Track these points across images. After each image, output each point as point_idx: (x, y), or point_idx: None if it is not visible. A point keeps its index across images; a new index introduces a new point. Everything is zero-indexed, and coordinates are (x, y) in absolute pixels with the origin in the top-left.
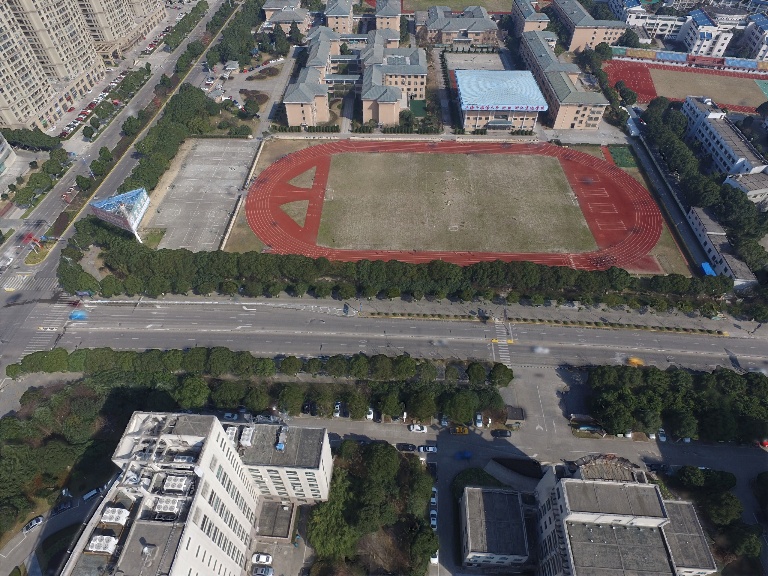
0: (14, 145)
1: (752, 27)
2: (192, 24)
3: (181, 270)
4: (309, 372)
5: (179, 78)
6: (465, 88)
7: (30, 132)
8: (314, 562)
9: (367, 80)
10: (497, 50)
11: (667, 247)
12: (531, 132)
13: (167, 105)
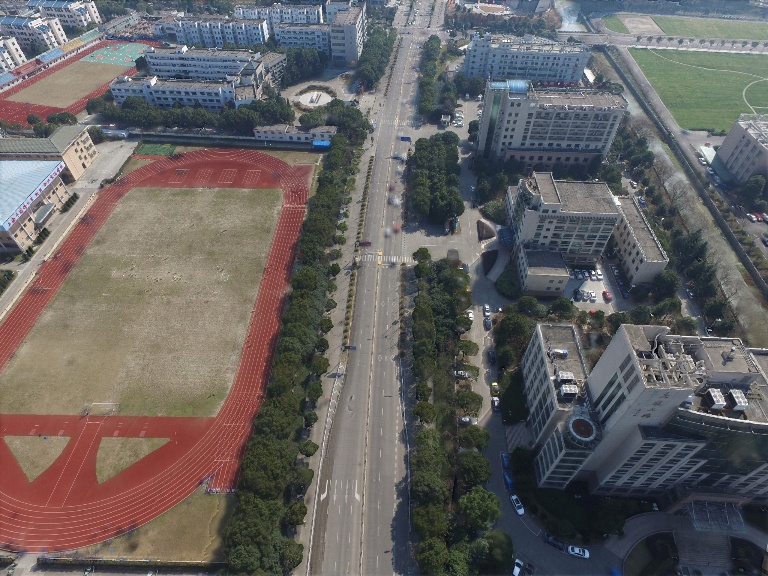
0: None
1: (3, 28)
2: None
3: None
4: None
5: None
6: None
7: None
8: None
9: None
10: None
11: (287, 156)
12: (76, 195)
13: None
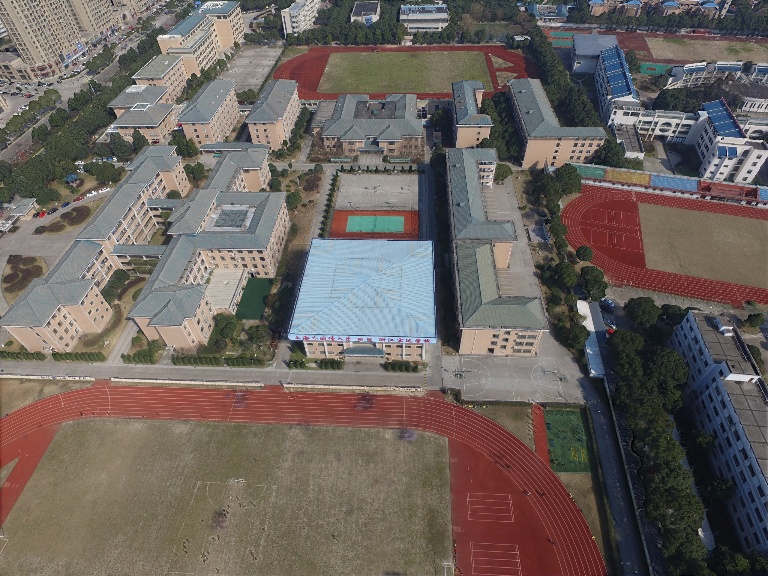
0: None
1: None
2: (18, 128)
3: None
4: None
5: None
6: (309, 288)
7: None
8: None
9: (157, 270)
10: (418, 166)
11: None
12: (415, 368)
13: None
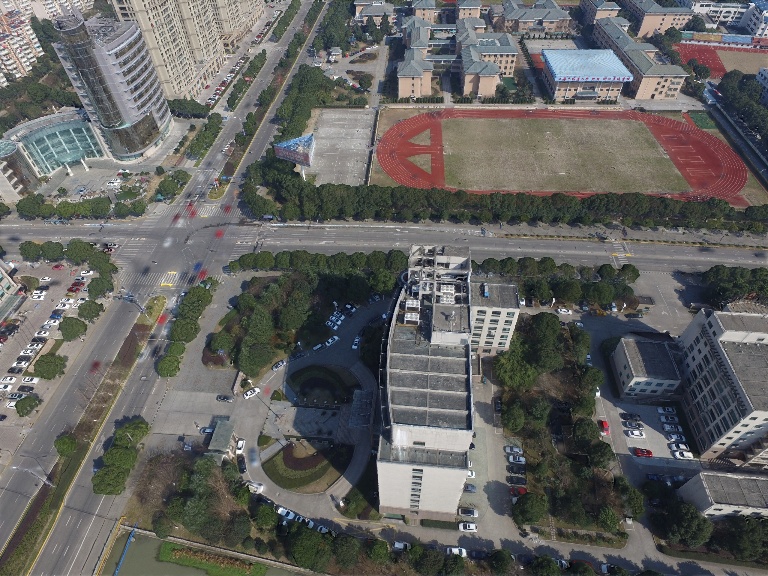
0: (171, 113)
1: None
2: (291, 19)
3: (346, 199)
4: None
5: (291, 62)
6: (555, 64)
7: (188, 101)
8: (503, 392)
9: (467, 58)
10: (570, 37)
11: (754, 189)
12: (616, 101)
13: (293, 81)
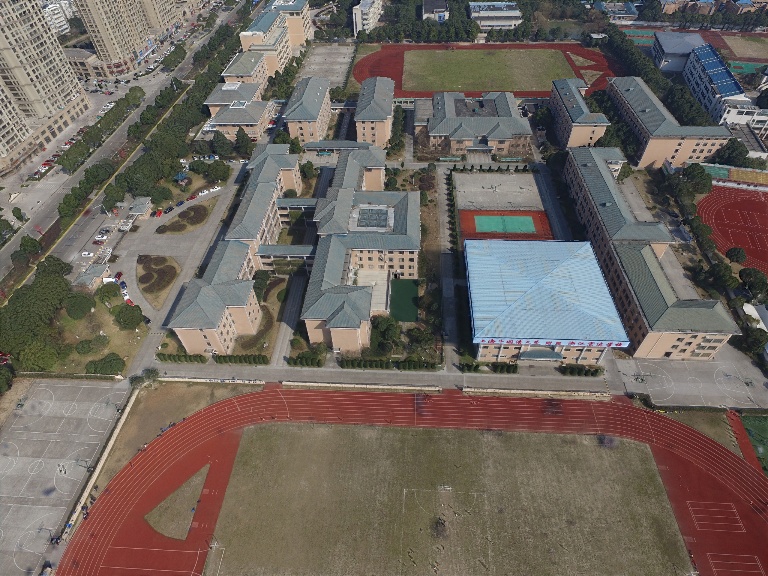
0: None
1: None
2: (111, 126)
3: None
4: None
5: (60, 229)
6: (480, 290)
7: None
8: None
9: (317, 271)
10: (530, 166)
11: None
12: (595, 372)
13: None
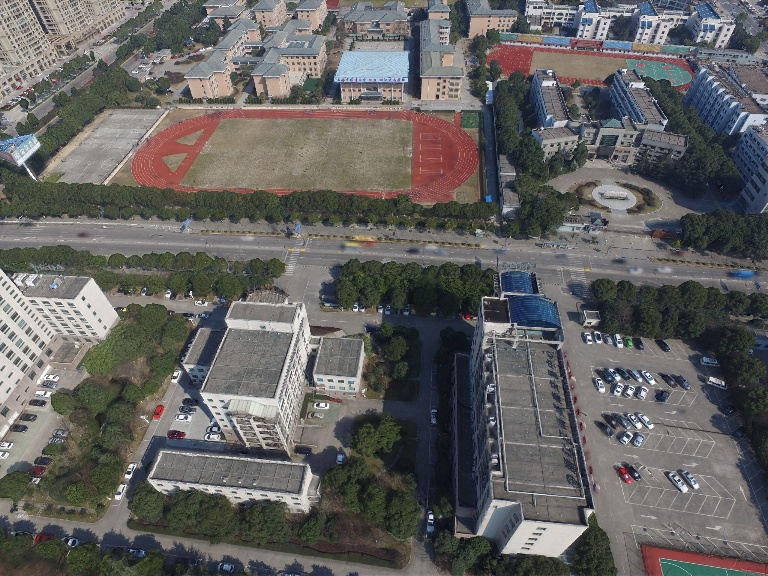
0: None
1: (638, 14)
2: (143, 21)
3: (56, 197)
4: (131, 265)
5: (118, 64)
6: (343, 65)
7: None
8: None
9: (261, 60)
10: (404, 38)
11: (469, 186)
12: (398, 102)
13: (93, 82)
